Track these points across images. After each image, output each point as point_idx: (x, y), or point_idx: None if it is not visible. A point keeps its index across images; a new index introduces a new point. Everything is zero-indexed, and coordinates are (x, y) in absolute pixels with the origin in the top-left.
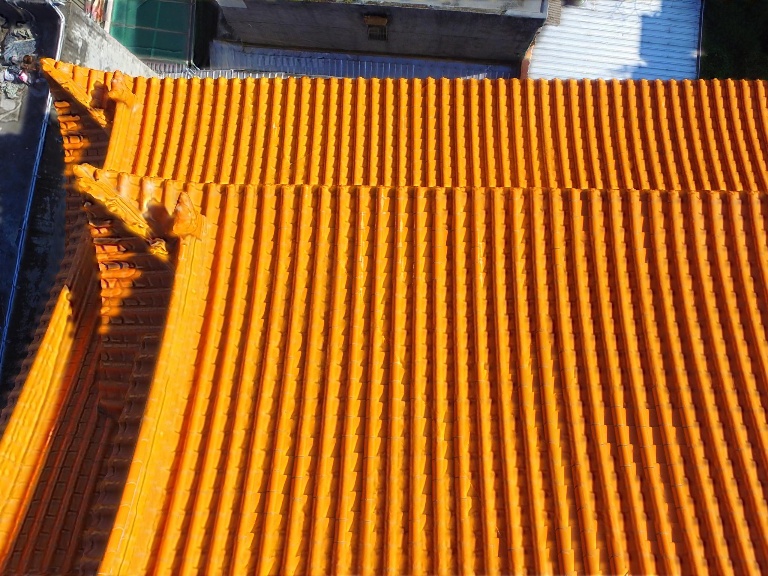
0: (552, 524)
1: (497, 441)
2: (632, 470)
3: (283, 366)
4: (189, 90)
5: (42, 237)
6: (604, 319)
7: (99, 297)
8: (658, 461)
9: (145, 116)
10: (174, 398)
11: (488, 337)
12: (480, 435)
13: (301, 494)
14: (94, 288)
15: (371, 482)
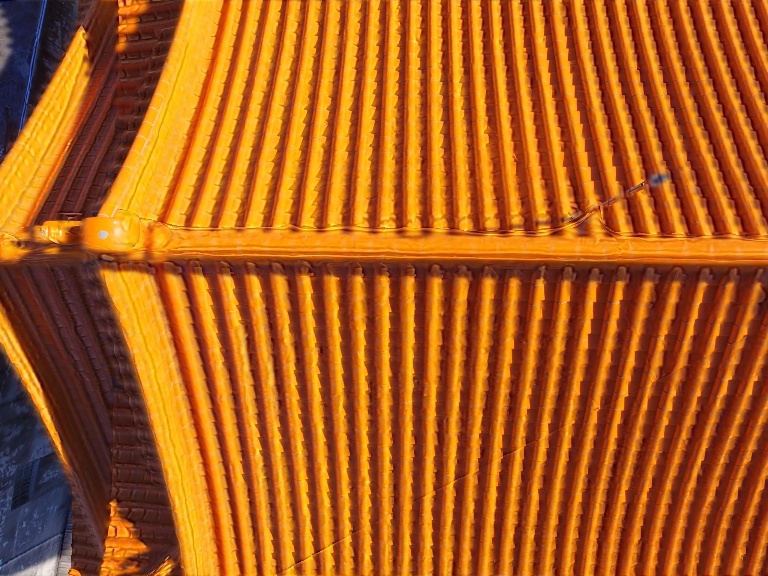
0: (569, 150)
1: (513, 95)
2: (647, 112)
3: (300, 46)
4: None
5: (53, 63)
6: (617, 4)
7: (114, 47)
8: (672, 106)
9: None
10: (193, 67)
11: (503, 21)
12: (496, 90)
13: (320, 135)
14: (109, 41)
15: (389, 125)
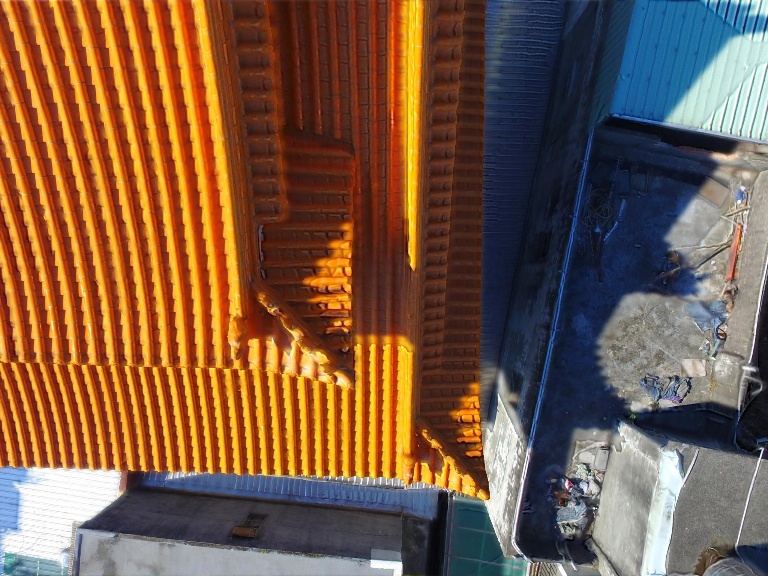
0: None
1: None
2: None
3: (132, 191)
4: (353, 465)
5: None
6: None
7: (393, 259)
8: None
9: (393, 440)
10: None
11: None
12: None
13: (71, 67)
14: (402, 268)
15: (10, 80)
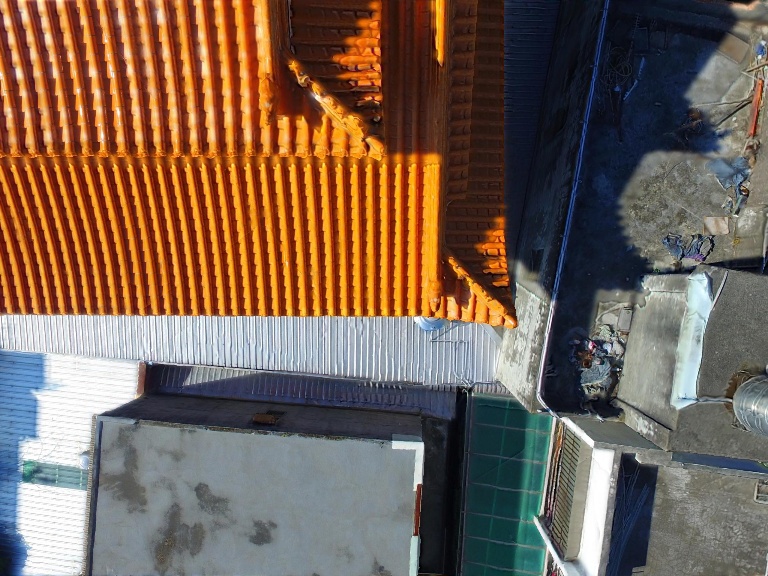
0: None
1: None
2: None
3: None
4: (378, 303)
5: None
6: None
7: (420, 63)
8: None
9: (418, 274)
10: None
11: None
12: None
13: None
14: (428, 74)
15: None
